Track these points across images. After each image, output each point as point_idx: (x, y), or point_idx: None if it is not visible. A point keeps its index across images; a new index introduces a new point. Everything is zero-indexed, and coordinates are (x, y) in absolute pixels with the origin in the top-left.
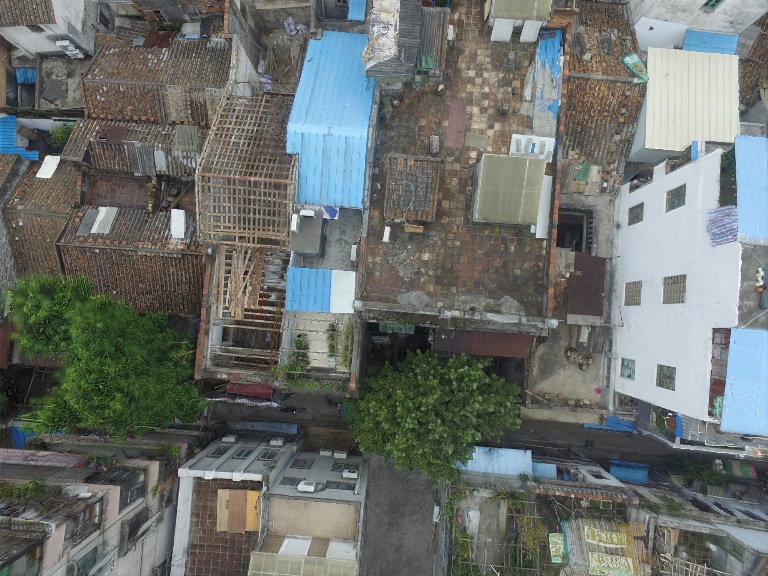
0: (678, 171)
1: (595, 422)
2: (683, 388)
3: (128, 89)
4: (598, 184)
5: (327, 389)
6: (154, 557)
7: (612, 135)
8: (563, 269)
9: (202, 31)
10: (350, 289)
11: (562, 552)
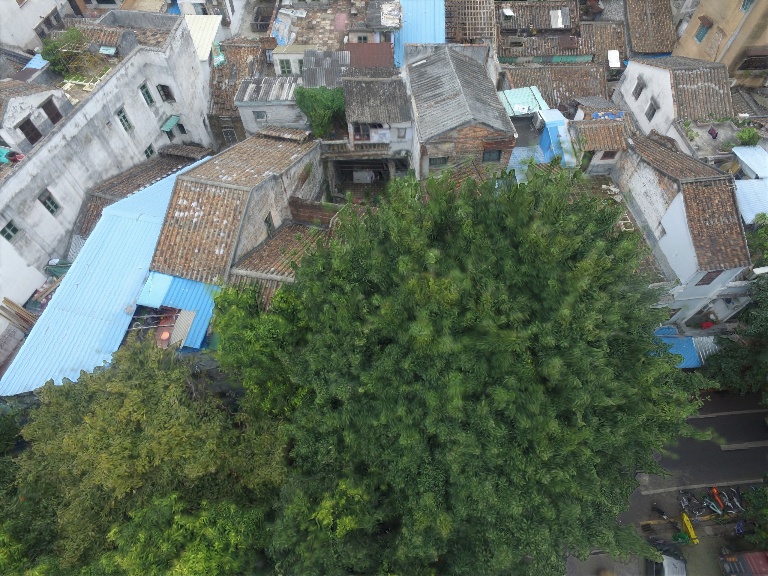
0: None
1: None
2: None
3: None
4: None
5: None
6: None
7: None
8: None
9: None
10: None
11: None
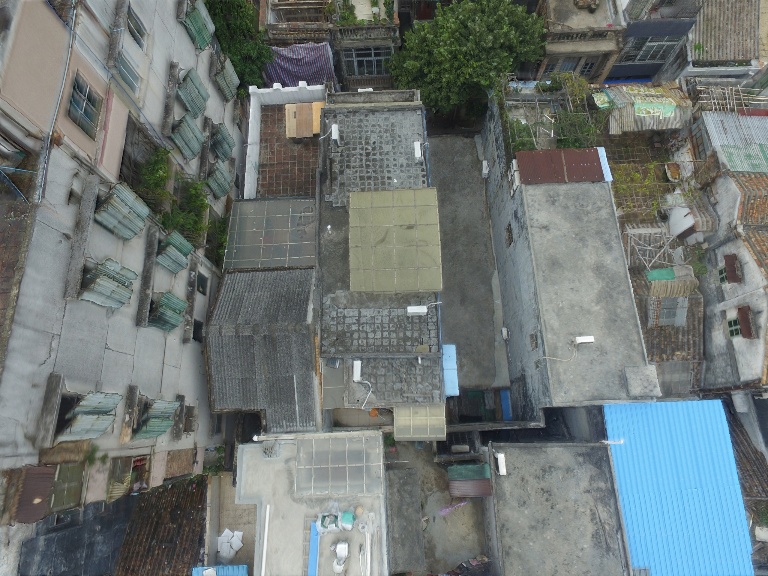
0: None
1: (613, 48)
2: None
3: None
4: None
5: (374, 42)
6: None
7: None
8: None
9: None
10: None
11: (607, 100)
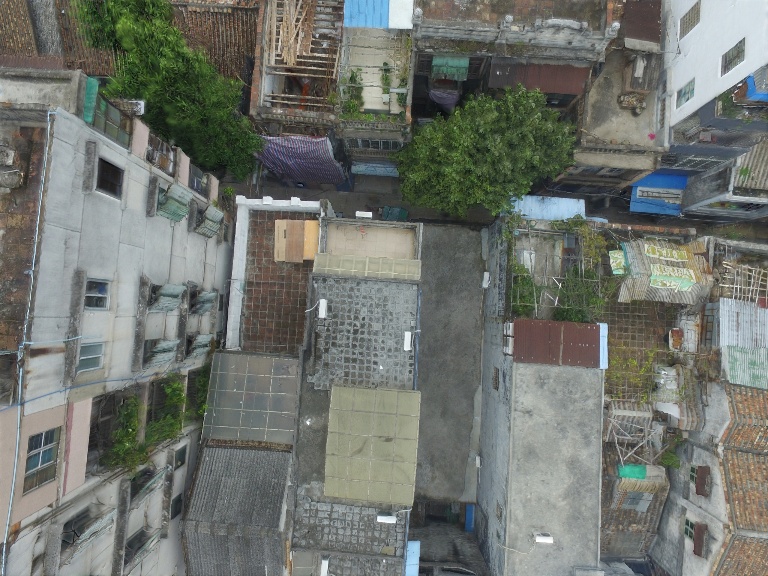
0: None
1: (649, 167)
2: (755, 47)
3: None
4: None
5: (380, 134)
6: (214, 278)
7: None
8: None
9: None
10: (408, 6)
11: (623, 265)
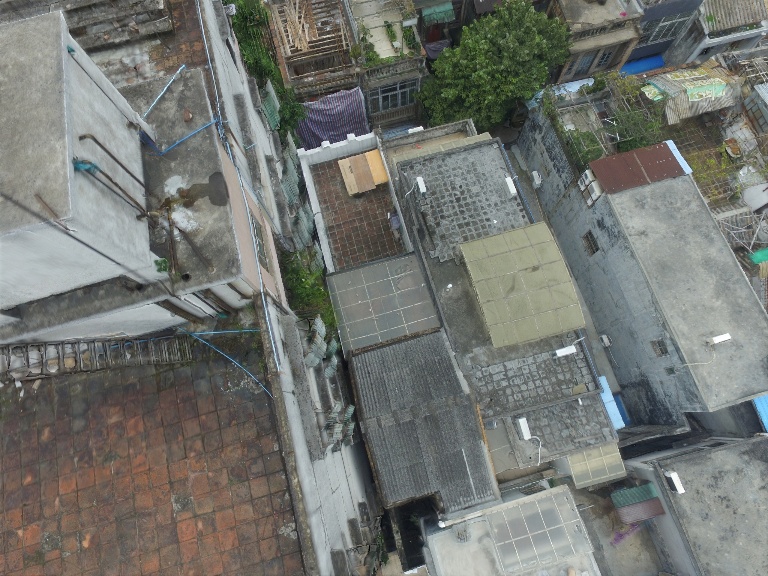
0: None
1: (633, 36)
2: None
3: None
4: None
5: (401, 77)
6: None
7: None
8: None
9: None
10: None
11: (658, 92)
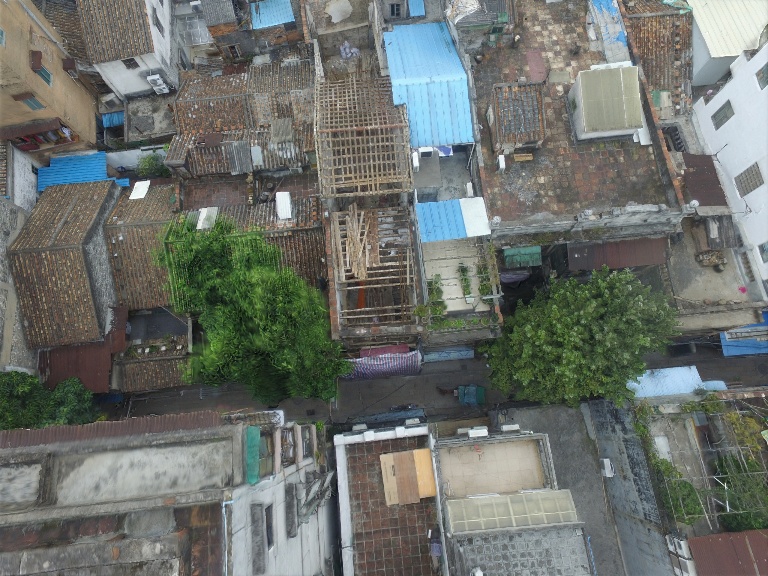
0: (763, 49)
1: (751, 321)
2: None
3: (218, 104)
4: (671, 108)
5: (468, 334)
6: (324, 545)
7: (672, 62)
8: (676, 168)
9: (272, 59)
10: (482, 213)
11: None
